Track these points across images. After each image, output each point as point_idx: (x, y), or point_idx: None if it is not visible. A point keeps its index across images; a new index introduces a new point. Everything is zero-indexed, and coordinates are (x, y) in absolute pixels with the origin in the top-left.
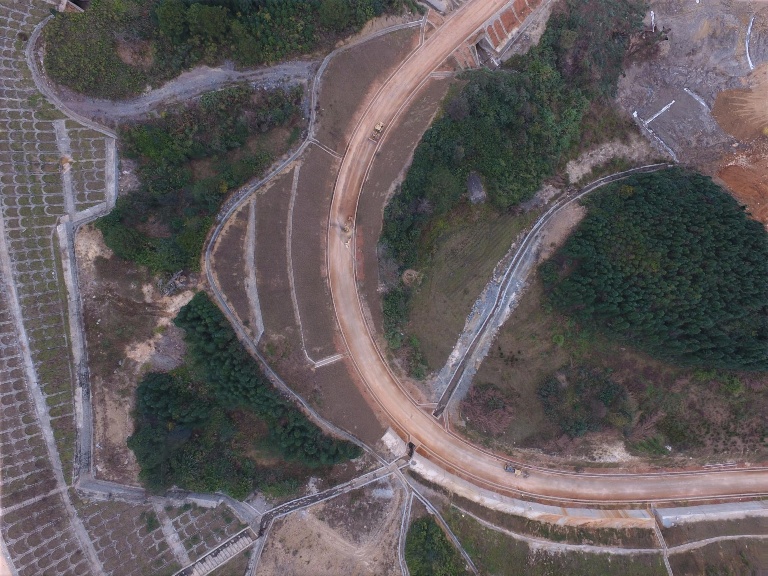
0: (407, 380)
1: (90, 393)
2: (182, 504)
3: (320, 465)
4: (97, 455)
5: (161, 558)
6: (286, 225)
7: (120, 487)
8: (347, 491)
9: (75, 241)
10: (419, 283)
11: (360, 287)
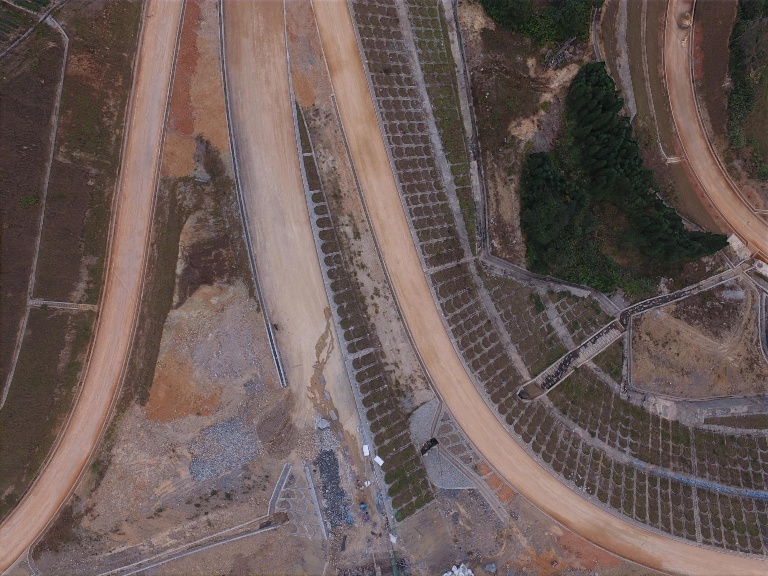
0: (746, 183)
1: (482, 168)
2: (561, 289)
3: (671, 265)
4: (492, 231)
5: (551, 339)
6: (641, 11)
7: (509, 267)
8: (696, 293)
9: (458, 14)
10: (756, 83)
11: (698, 87)
